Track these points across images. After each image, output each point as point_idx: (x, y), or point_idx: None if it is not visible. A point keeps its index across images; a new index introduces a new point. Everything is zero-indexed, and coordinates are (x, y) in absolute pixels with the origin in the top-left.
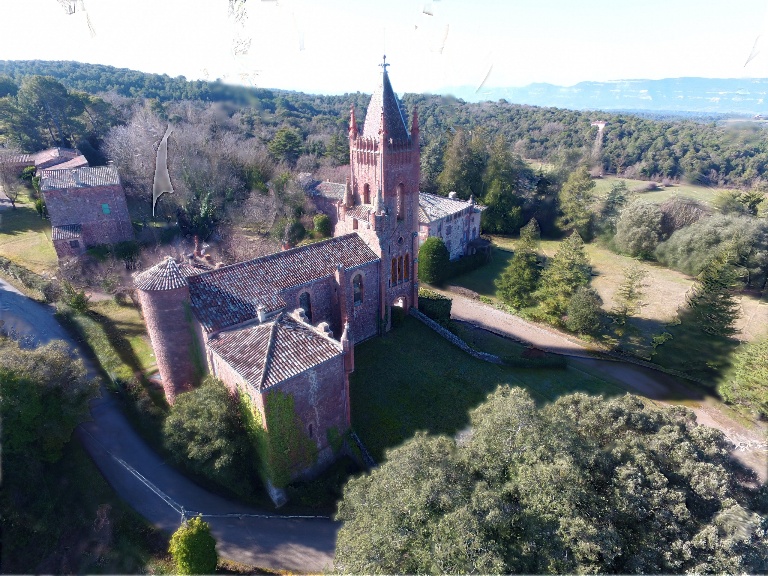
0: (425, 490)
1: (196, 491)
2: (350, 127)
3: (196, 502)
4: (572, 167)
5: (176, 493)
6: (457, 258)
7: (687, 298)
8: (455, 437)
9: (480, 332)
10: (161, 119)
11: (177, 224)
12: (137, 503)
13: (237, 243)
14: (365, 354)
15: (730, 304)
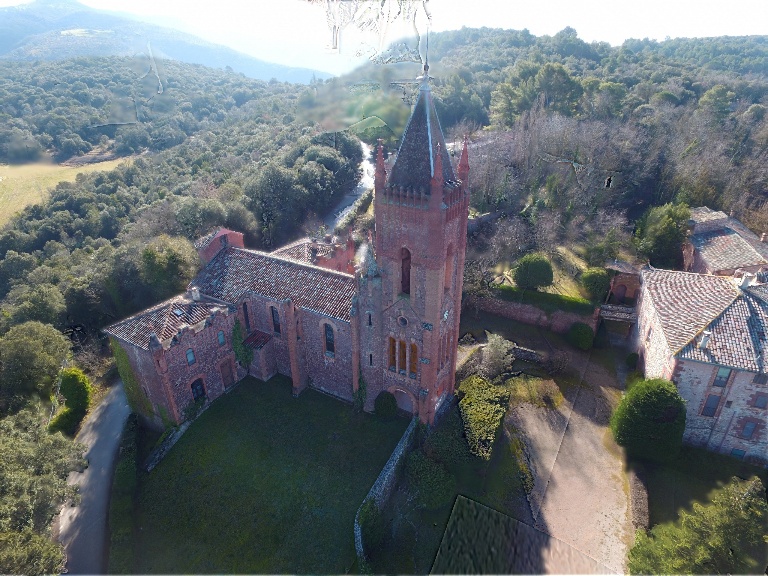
0: None
1: None
2: None
3: None
4: None
5: None
6: None
7: None
8: None
9: None
10: (562, 114)
11: (474, 219)
12: None
13: None
14: (311, 405)
15: None
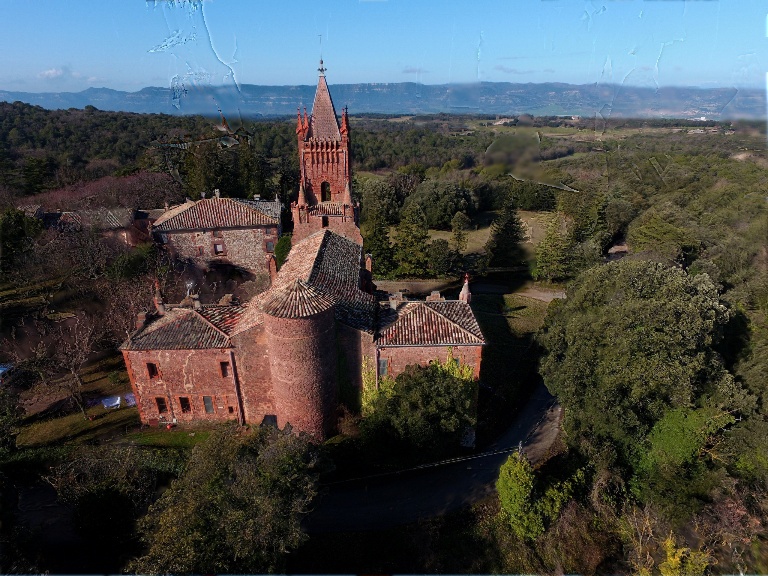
0: (671, 309)
1: (420, 480)
2: (300, 129)
3: (433, 485)
4: None
5: (412, 492)
6: None
7: (494, 228)
8: None
9: None
10: None
11: None
12: (401, 520)
13: (123, 291)
14: None
15: (521, 223)
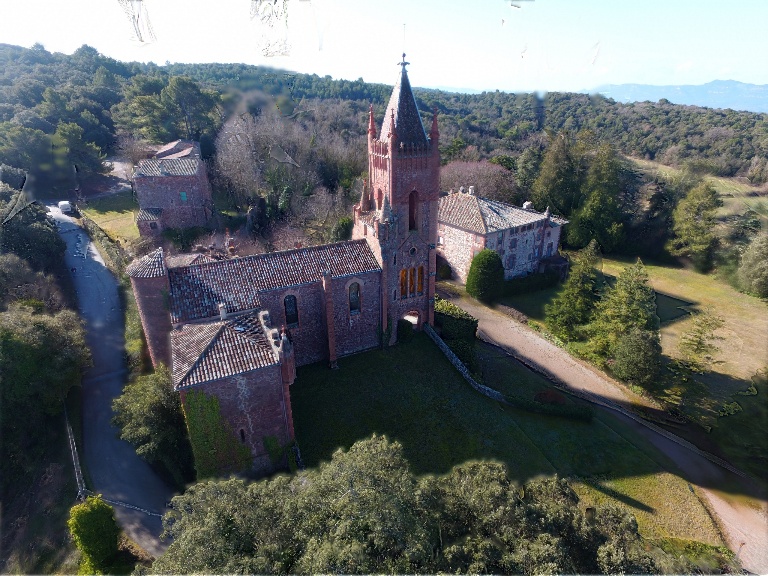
0: None
1: (145, 469)
2: None
3: (139, 480)
4: (695, 181)
5: (128, 467)
6: (524, 275)
7: None
8: (292, 483)
9: (509, 361)
10: (258, 116)
11: (249, 214)
12: (94, 468)
13: (283, 237)
14: (355, 366)
15: None
